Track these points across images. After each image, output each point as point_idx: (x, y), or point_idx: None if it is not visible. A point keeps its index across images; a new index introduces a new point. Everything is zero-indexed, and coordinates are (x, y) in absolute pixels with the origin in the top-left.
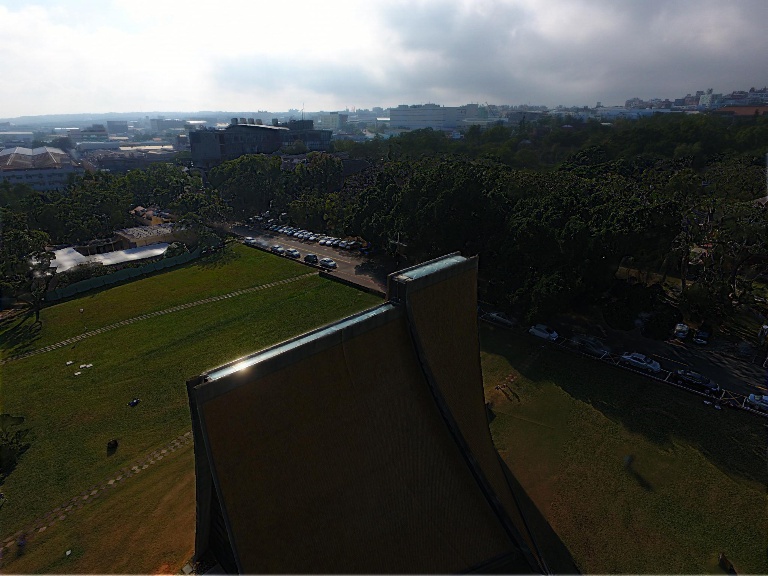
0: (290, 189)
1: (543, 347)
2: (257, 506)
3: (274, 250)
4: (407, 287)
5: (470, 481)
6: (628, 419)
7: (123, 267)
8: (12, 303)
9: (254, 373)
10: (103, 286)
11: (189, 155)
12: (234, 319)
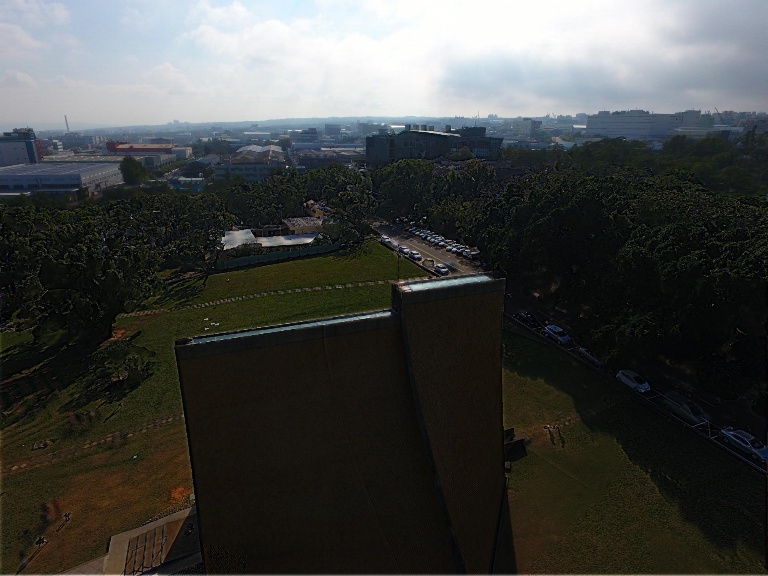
0: (439, 194)
1: (625, 397)
2: (219, 457)
3: (401, 251)
4: (402, 298)
5: (435, 504)
6: (689, 505)
7: (276, 250)
8: (195, 267)
9: (229, 346)
10: (258, 263)
11: (364, 157)
12: (335, 307)
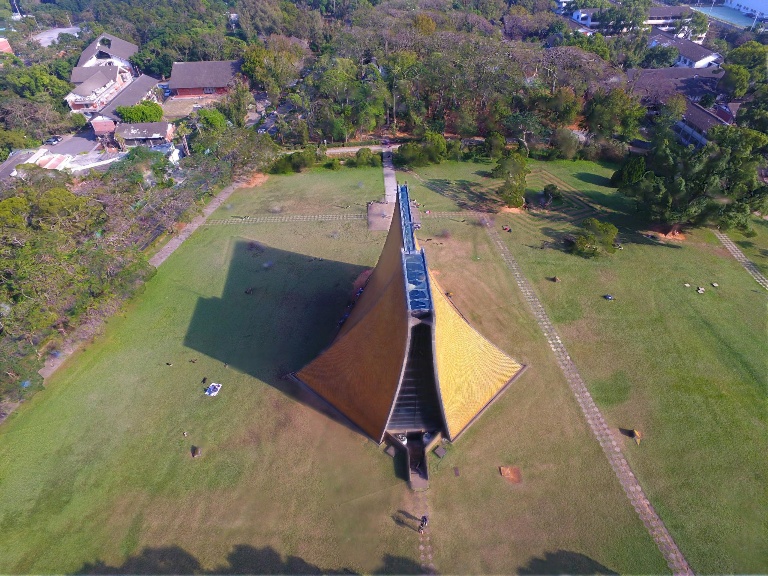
0: None
1: None
2: None
3: None
4: None
5: None
6: (277, 570)
7: None
8: None
9: None
10: None
11: None
12: None
